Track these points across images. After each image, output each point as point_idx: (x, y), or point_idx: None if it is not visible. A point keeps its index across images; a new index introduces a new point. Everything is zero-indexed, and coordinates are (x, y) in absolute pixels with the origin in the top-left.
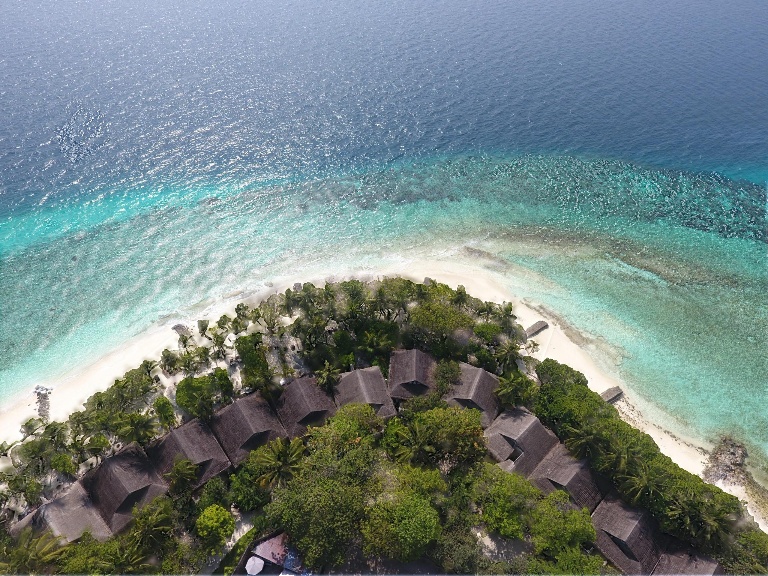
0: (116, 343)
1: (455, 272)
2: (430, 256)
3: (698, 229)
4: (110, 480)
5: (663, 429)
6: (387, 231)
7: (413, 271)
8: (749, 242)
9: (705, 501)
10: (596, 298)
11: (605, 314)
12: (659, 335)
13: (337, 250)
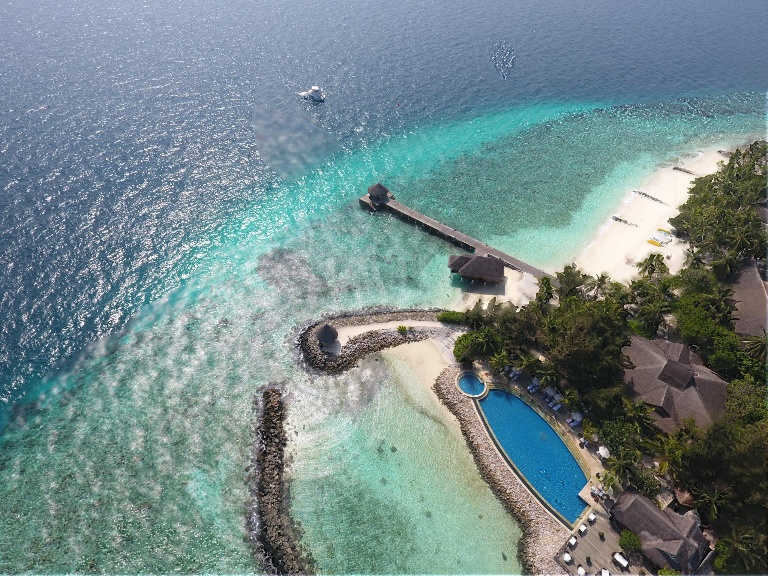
0: (648, 175)
1: None
2: None
3: None
4: (765, 211)
5: None
6: (738, 128)
7: None
8: None
9: None
10: None
11: None
12: None
13: (720, 137)
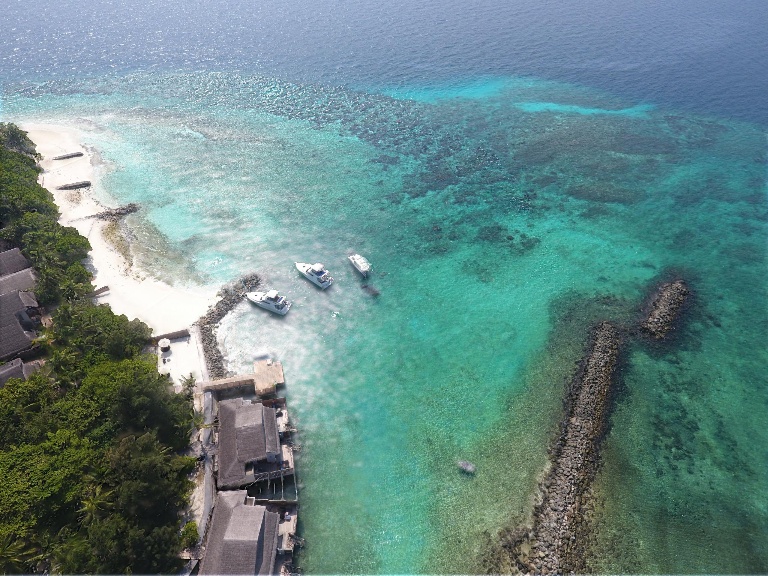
0: None
1: (51, 129)
2: (44, 122)
3: (275, 114)
4: None
5: (96, 200)
6: (30, 109)
7: (20, 128)
8: (304, 122)
9: (9, 197)
10: (141, 145)
11: (135, 152)
12: (160, 162)
13: None
